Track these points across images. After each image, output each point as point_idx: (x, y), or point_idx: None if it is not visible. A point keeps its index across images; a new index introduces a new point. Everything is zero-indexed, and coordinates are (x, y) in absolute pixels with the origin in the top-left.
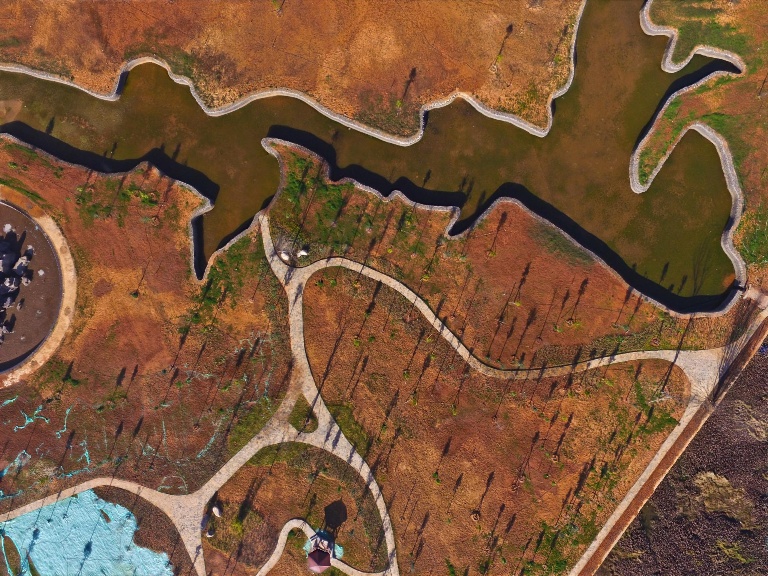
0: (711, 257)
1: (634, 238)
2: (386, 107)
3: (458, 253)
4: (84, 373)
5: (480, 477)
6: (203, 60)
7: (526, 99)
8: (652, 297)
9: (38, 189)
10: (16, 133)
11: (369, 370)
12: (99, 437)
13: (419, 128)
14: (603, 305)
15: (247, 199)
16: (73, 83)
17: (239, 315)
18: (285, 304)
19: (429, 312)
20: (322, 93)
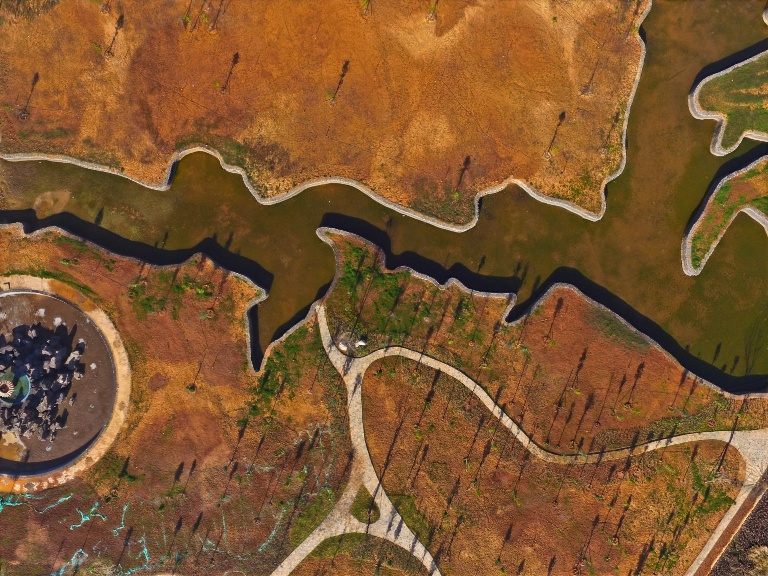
0: (762, 337)
1: (687, 319)
2: (441, 195)
3: (515, 339)
4: (141, 469)
5: (542, 562)
6: (256, 150)
7: (580, 185)
8: (704, 376)
9: (90, 283)
10: (64, 225)
11: (429, 459)
12: (158, 534)
13: (474, 216)
14: (659, 388)
15: (302, 287)
16: (123, 175)
17: (298, 406)
18: (344, 395)
19: (488, 399)
20: (377, 182)
